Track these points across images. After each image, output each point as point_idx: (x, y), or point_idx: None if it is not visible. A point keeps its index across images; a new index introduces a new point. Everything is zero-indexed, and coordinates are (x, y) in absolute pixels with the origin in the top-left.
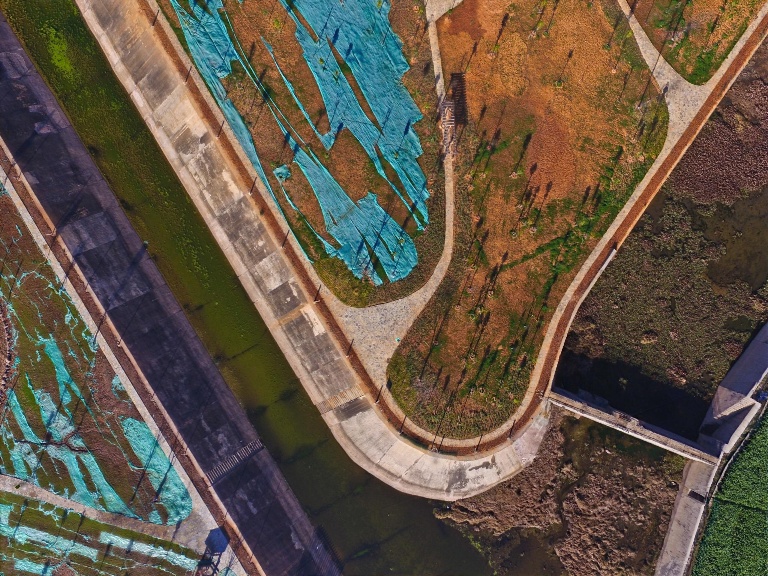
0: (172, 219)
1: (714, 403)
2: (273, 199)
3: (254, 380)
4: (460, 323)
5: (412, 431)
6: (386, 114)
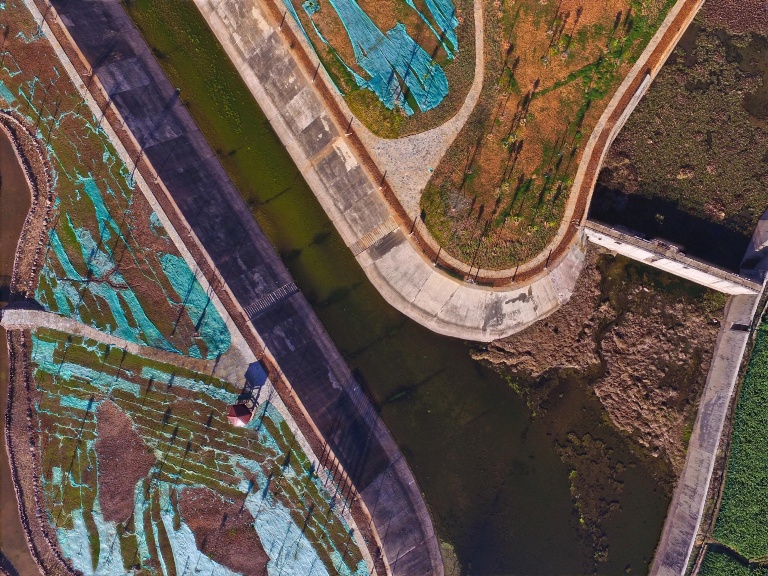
0: (203, 66)
1: (755, 237)
2: (303, 33)
3: (288, 224)
4: (493, 152)
5: (447, 262)
6: None
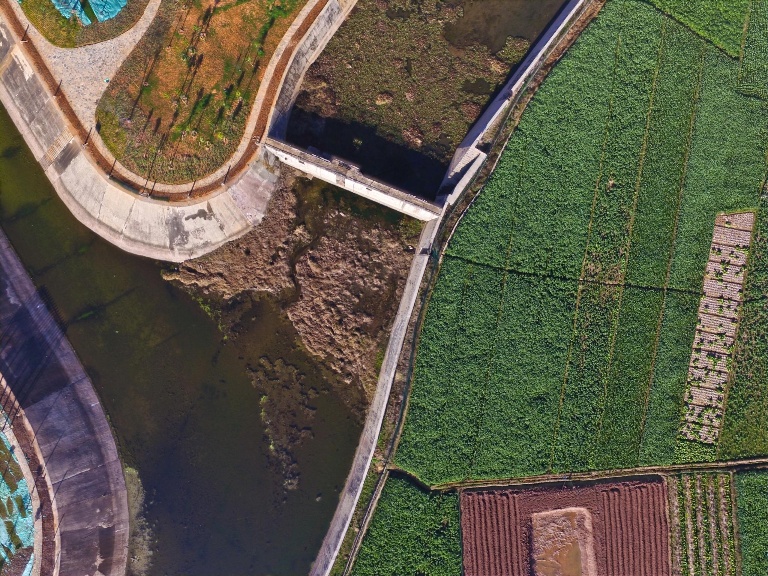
0: None
1: (451, 165)
2: None
3: None
4: (171, 65)
5: (122, 175)
6: None
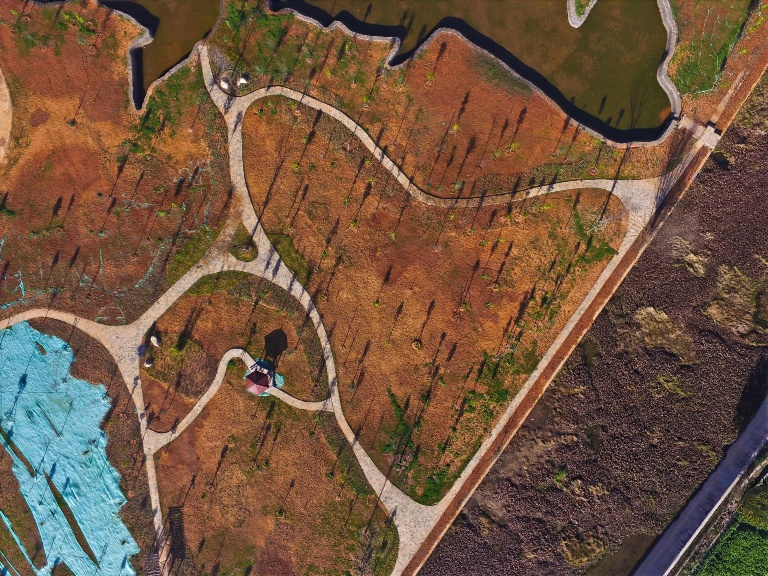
0: None
1: None
2: None
3: None
4: None
5: None
6: (103, 548)
